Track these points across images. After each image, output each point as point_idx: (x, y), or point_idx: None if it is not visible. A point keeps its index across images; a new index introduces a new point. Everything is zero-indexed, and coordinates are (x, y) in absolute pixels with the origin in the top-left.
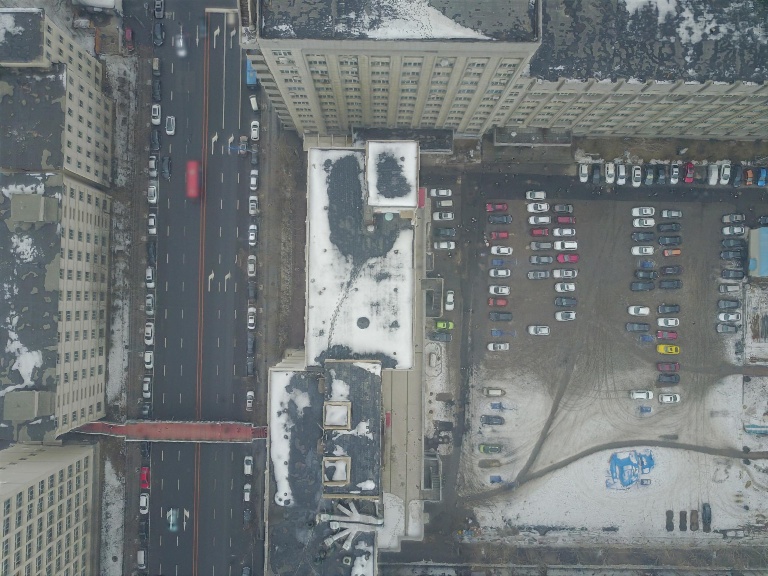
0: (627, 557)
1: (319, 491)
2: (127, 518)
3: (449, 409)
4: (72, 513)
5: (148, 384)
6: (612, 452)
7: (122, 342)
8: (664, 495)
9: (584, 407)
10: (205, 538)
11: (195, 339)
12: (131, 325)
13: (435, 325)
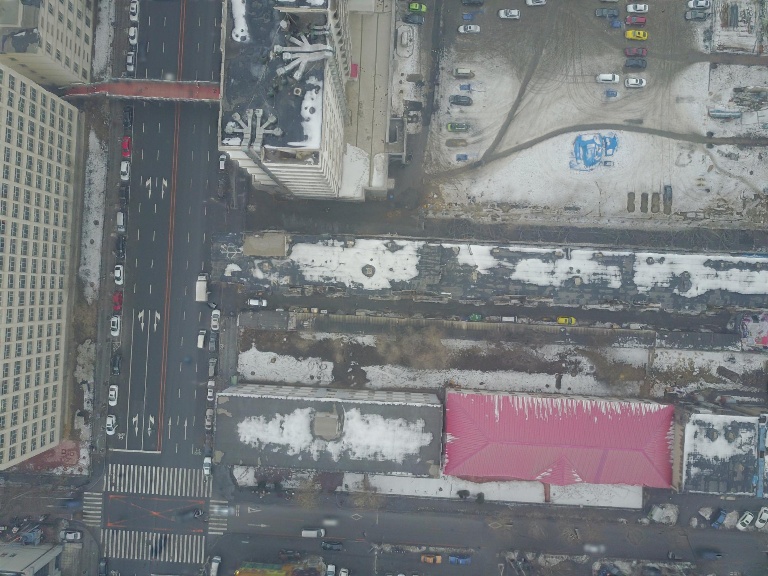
0: (588, 236)
1: (274, 29)
2: (109, 185)
3: (419, 90)
4: (54, 148)
5: (132, 56)
6: (577, 134)
7: (109, 19)
8: (627, 177)
9: (551, 90)
10: (182, 206)
11: (178, 18)
12: (117, 3)
13: (408, 7)
